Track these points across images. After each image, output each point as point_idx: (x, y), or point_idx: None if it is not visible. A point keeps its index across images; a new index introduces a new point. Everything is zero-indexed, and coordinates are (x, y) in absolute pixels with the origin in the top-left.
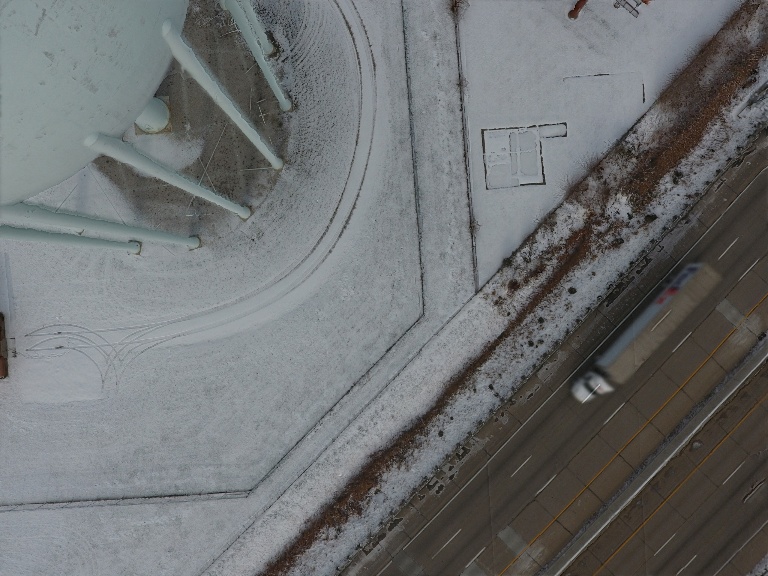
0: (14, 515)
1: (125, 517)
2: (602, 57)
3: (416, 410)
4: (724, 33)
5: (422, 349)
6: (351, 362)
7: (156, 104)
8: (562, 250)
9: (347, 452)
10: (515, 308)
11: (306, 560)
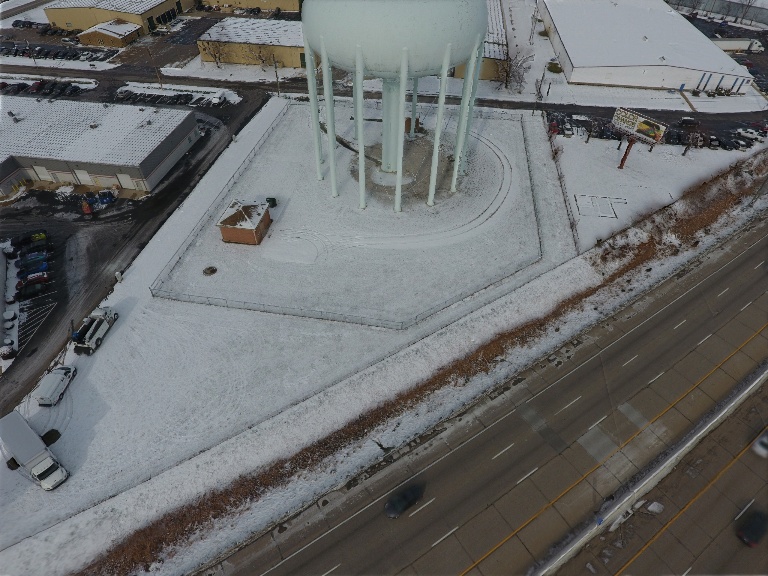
0: (219, 312)
1: (299, 328)
2: (641, 182)
3: (536, 314)
4: (712, 183)
5: (541, 275)
6: (489, 273)
7: None
8: (636, 251)
9: (481, 324)
10: (607, 273)
11: (434, 398)
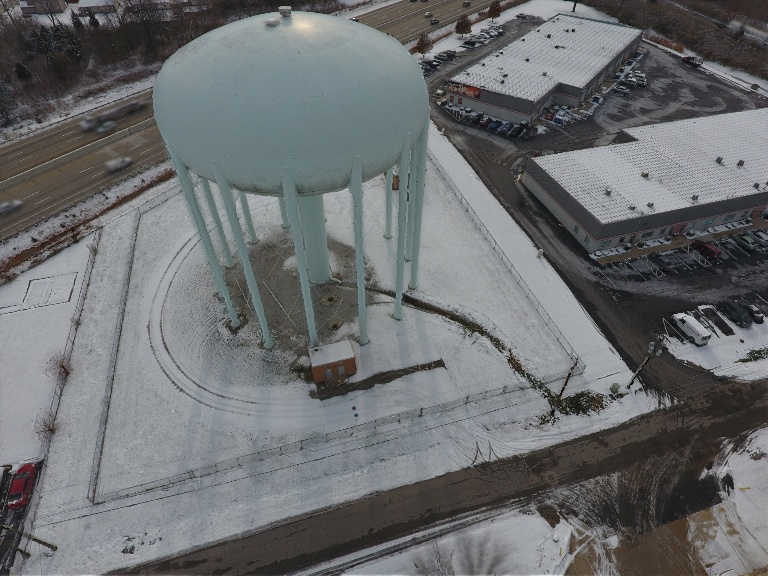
0: None
1: None
2: None
3: None
4: None
5: None
6: None
7: (309, 269)
8: None
9: None
10: None
11: None
